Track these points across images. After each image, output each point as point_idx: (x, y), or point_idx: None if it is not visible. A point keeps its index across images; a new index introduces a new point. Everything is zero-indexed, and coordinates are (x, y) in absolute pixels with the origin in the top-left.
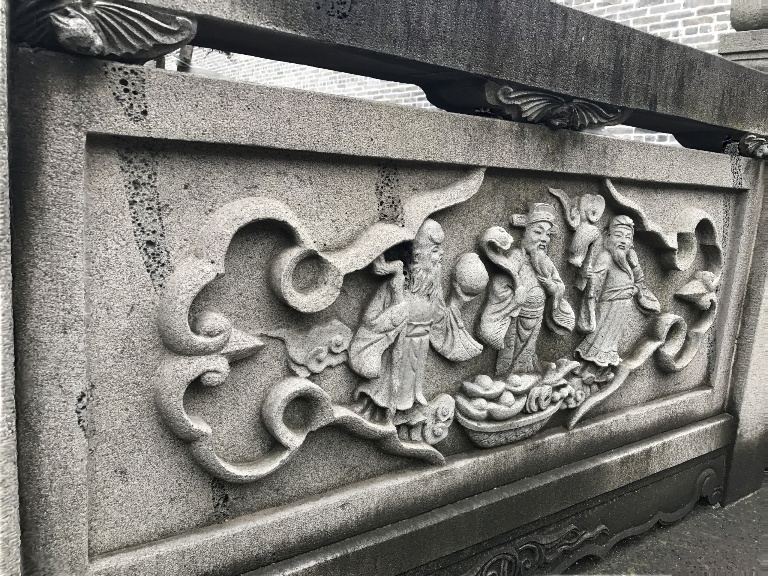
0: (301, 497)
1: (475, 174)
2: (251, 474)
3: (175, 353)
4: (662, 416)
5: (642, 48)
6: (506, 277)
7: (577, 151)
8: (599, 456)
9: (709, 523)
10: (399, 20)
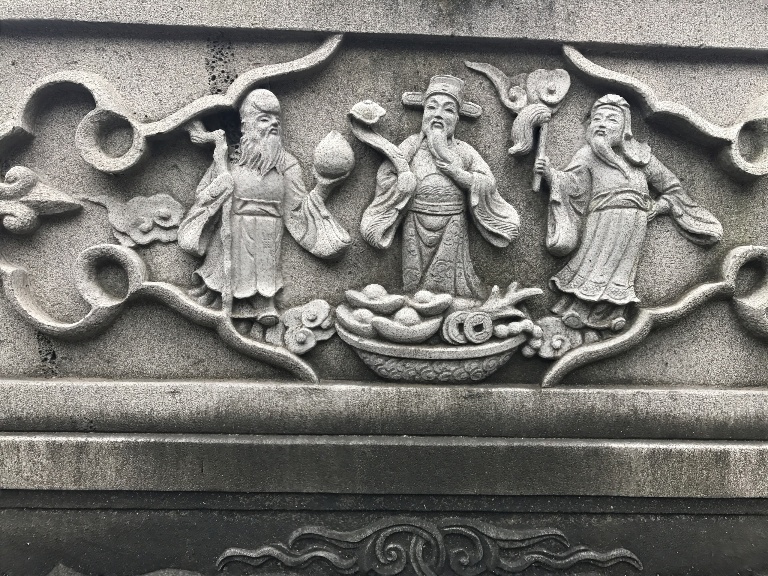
0: (136, 376)
1: (328, 42)
2: (56, 325)
3: None
4: (766, 411)
5: None
6: (389, 162)
7: (495, 10)
8: (610, 440)
9: None
10: None
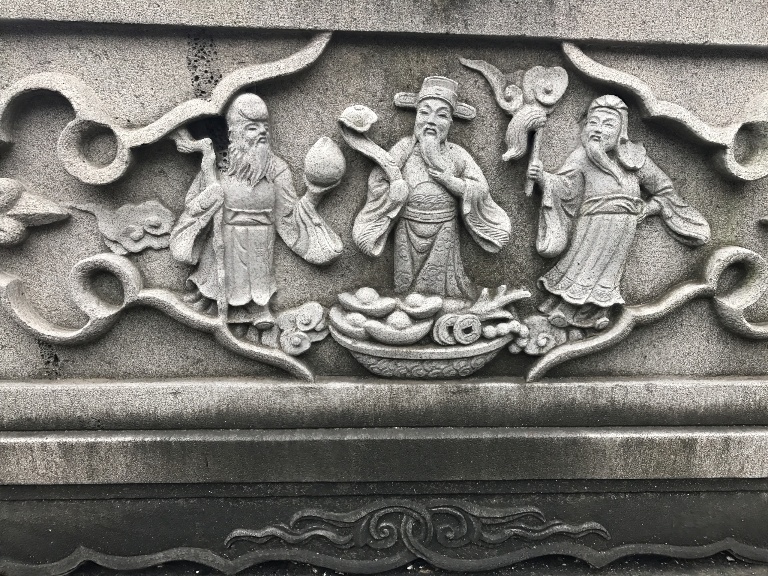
0: (137, 376)
1: (316, 41)
2: (56, 335)
3: None
4: (734, 400)
5: None
6: (381, 168)
7: (493, 5)
8: (588, 428)
9: None
10: None
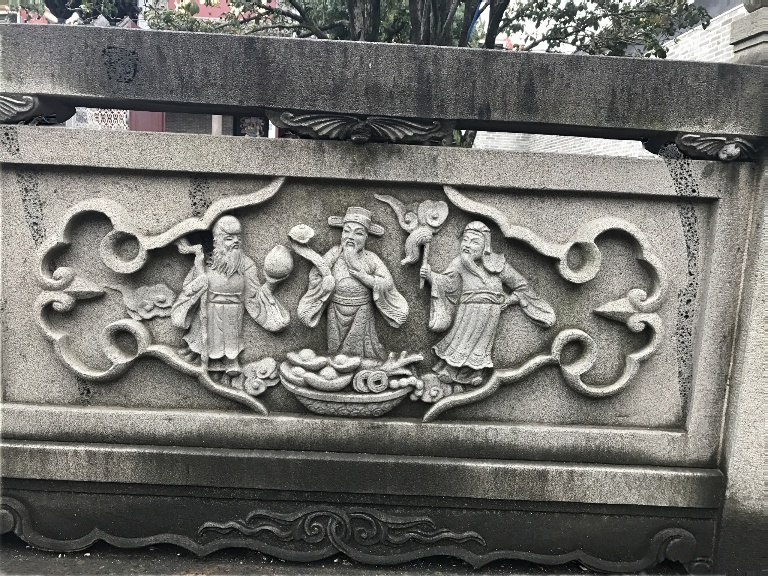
0: (144, 406)
1: (275, 182)
2: (89, 374)
3: None
4: (580, 443)
5: (458, 63)
6: None
7: (394, 161)
8: (468, 459)
9: None
10: (173, 77)
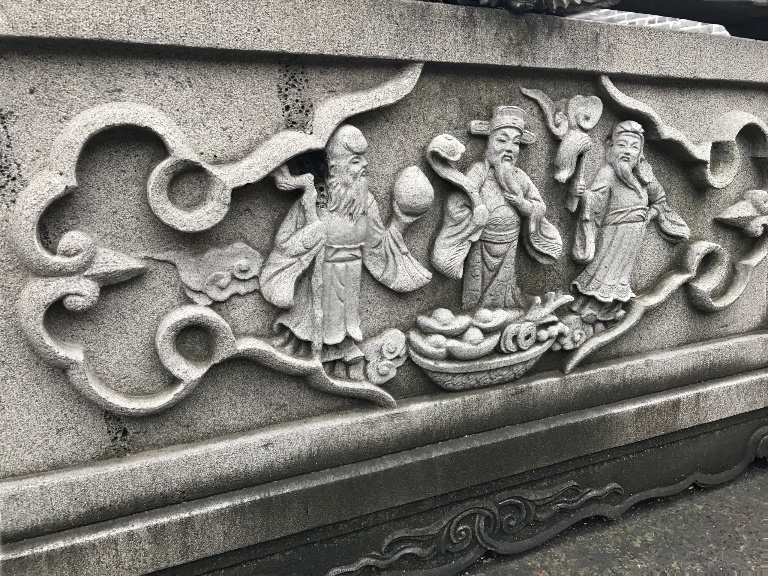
0: (218, 435)
1: (409, 71)
2: (140, 407)
3: (34, 275)
4: (698, 363)
5: None
6: (462, 195)
7: (555, 40)
8: (608, 405)
9: (764, 488)
10: None
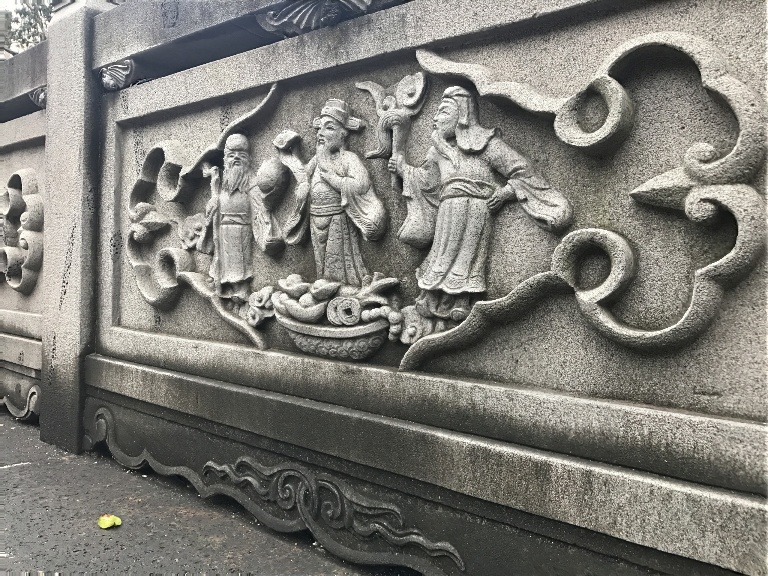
0: (189, 336)
1: None
2: None
3: None
4: (615, 429)
5: None
6: None
7: (365, 35)
8: (448, 431)
9: None
10: (198, 9)
